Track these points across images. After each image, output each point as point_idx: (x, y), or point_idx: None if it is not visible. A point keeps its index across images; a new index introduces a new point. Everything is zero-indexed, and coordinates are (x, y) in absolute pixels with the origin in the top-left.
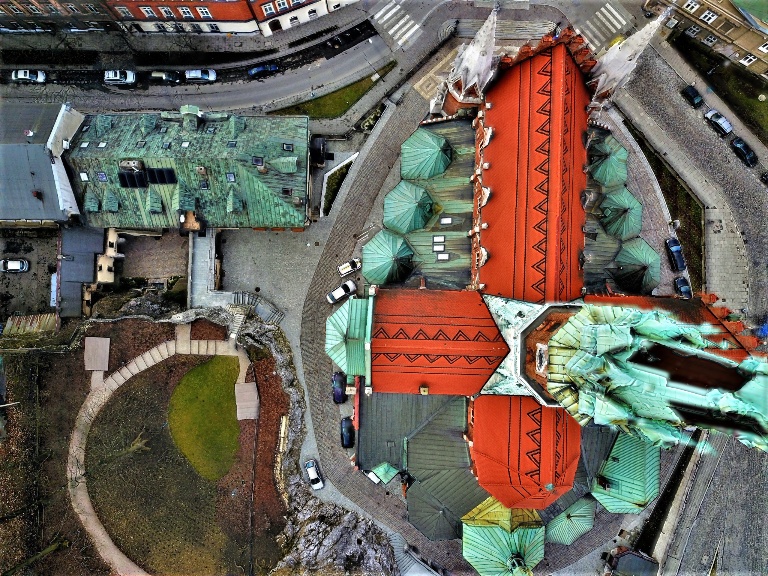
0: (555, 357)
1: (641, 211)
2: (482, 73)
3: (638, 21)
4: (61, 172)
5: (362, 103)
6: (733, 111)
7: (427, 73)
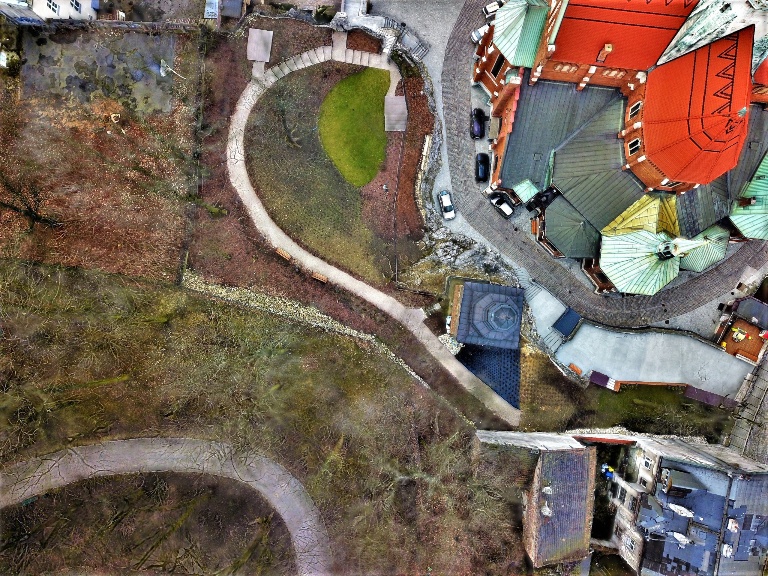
0: None
1: None
2: None
3: None
4: None
5: None
6: None
7: None
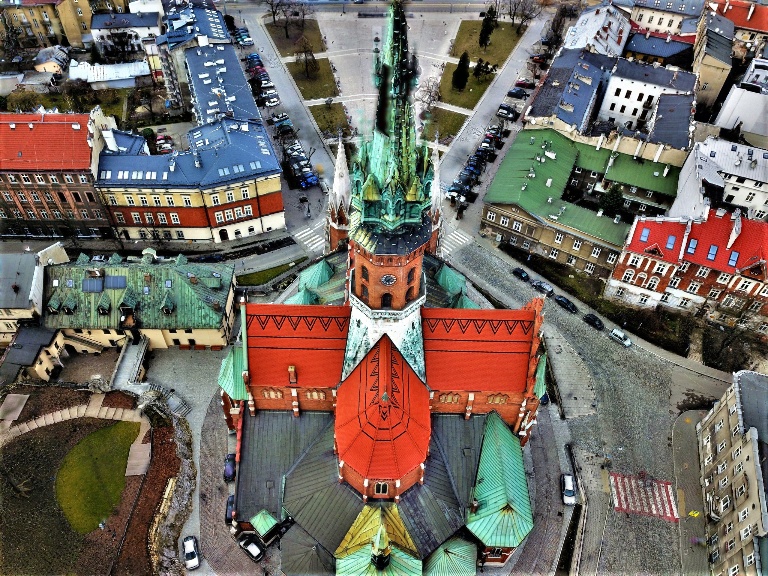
0: (353, 218)
1: None
2: (345, 195)
3: (477, 239)
4: (40, 276)
5: (280, 278)
6: (552, 282)
7: None
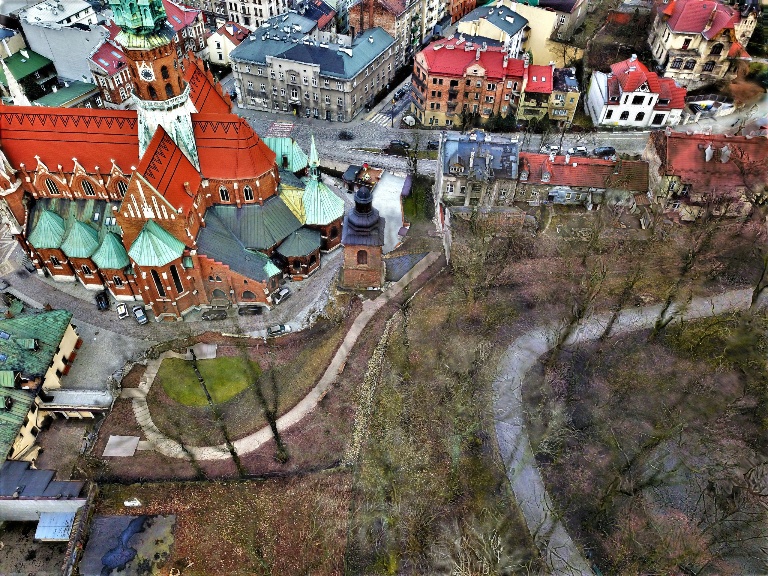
0: (133, 44)
1: None
2: None
3: None
4: None
5: None
6: None
7: None
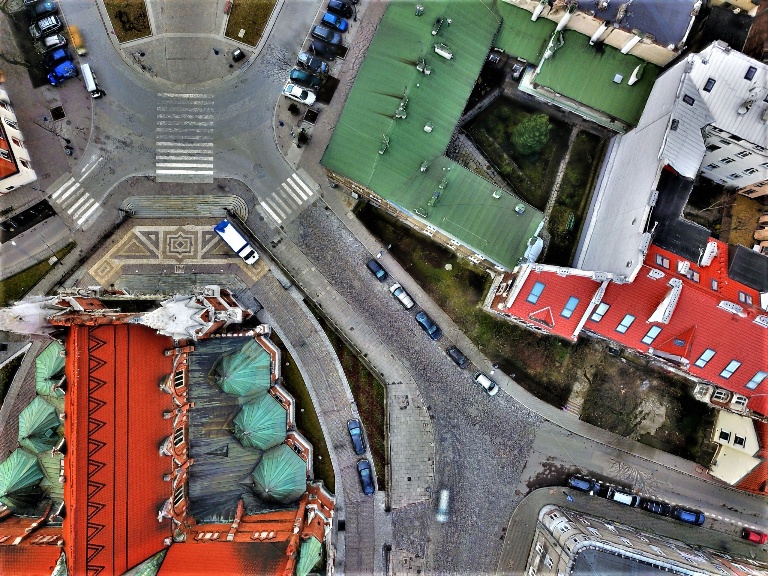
0: None
1: (285, 417)
2: (35, 333)
3: (325, 191)
4: None
5: (39, 288)
6: None
7: (102, 257)
